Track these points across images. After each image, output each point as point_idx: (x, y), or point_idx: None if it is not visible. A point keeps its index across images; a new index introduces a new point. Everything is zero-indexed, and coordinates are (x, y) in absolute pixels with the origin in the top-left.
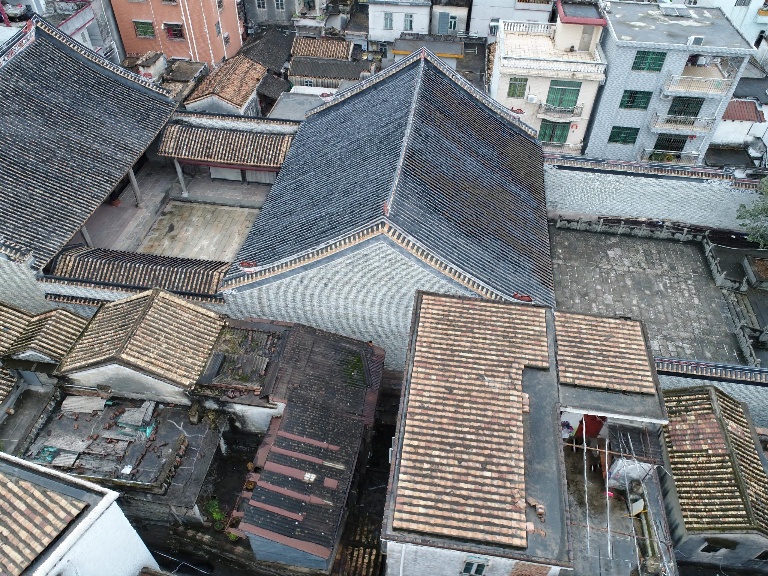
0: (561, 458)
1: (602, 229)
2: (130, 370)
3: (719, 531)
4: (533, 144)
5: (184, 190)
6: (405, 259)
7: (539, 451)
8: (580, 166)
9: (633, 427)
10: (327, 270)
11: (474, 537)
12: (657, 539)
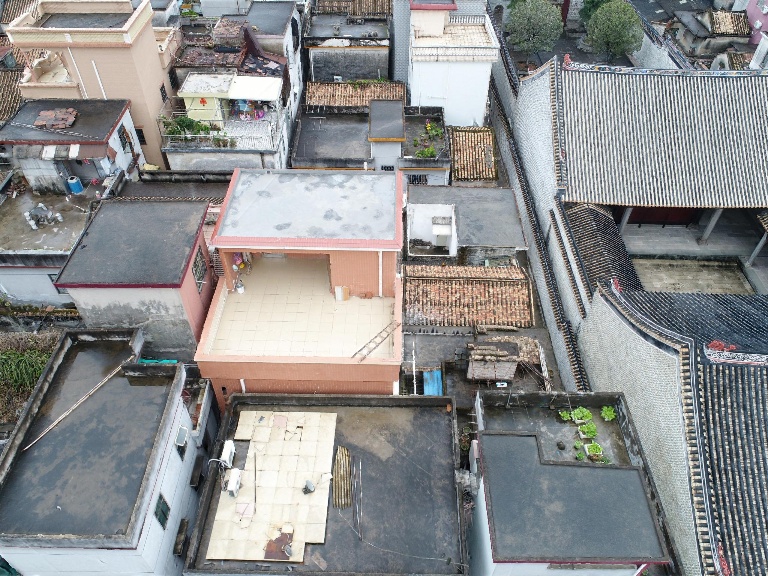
0: None
1: None
2: None
3: None
4: None
5: None
6: None
7: None
8: None
9: None
10: None
11: None
12: None
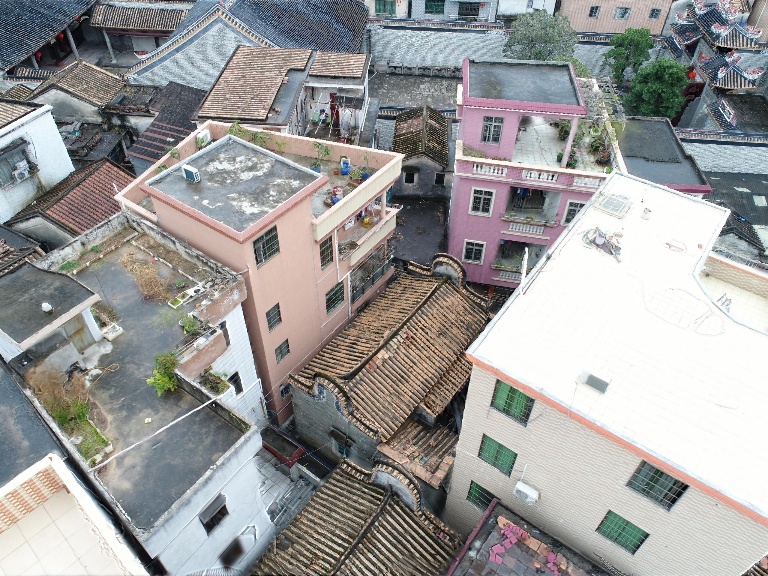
0: (297, 96)
1: (419, 72)
2: (63, 94)
3: (405, 159)
4: (362, 8)
5: (113, 58)
6: (237, 37)
7: (286, 95)
8: (399, 25)
9: (350, 97)
10: (191, 51)
11: (239, 117)
12: (342, 127)
